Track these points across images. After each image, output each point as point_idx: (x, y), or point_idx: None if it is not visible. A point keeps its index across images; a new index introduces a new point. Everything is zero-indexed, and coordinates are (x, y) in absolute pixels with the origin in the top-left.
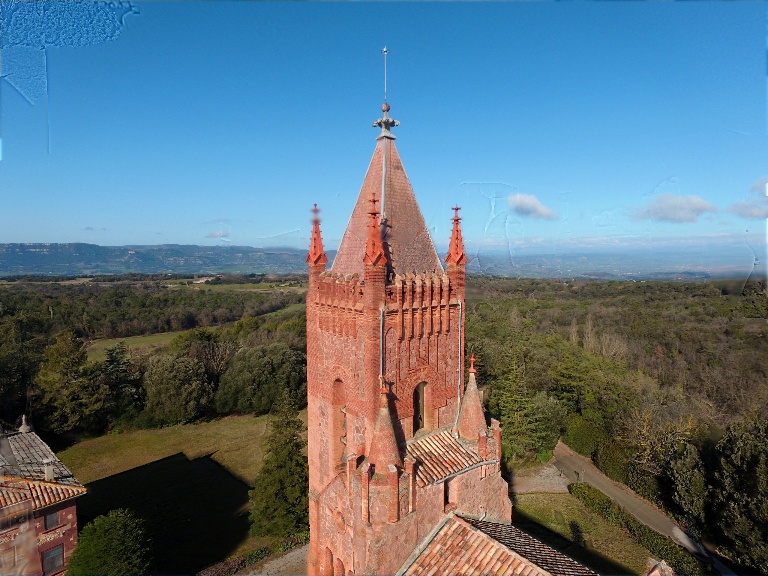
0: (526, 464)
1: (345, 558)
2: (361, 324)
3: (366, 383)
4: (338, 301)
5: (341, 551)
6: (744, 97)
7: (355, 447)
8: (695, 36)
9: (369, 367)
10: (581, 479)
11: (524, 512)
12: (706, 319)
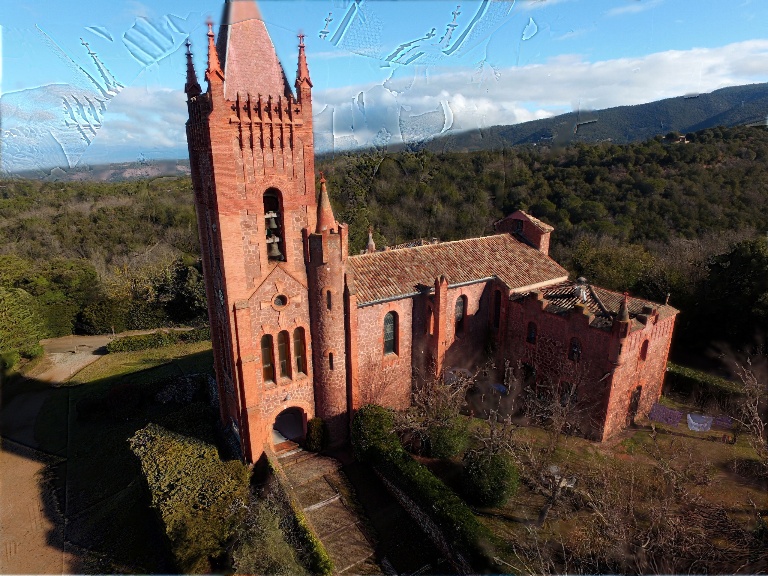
0: (34, 362)
1: (289, 325)
2: (300, 136)
3: (307, 180)
4: (273, 118)
5: (285, 322)
6: (495, 51)
7: (297, 233)
8: (499, 33)
9: (310, 167)
10: (94, 345)
11: (104, 378)
12: (85, 193)
